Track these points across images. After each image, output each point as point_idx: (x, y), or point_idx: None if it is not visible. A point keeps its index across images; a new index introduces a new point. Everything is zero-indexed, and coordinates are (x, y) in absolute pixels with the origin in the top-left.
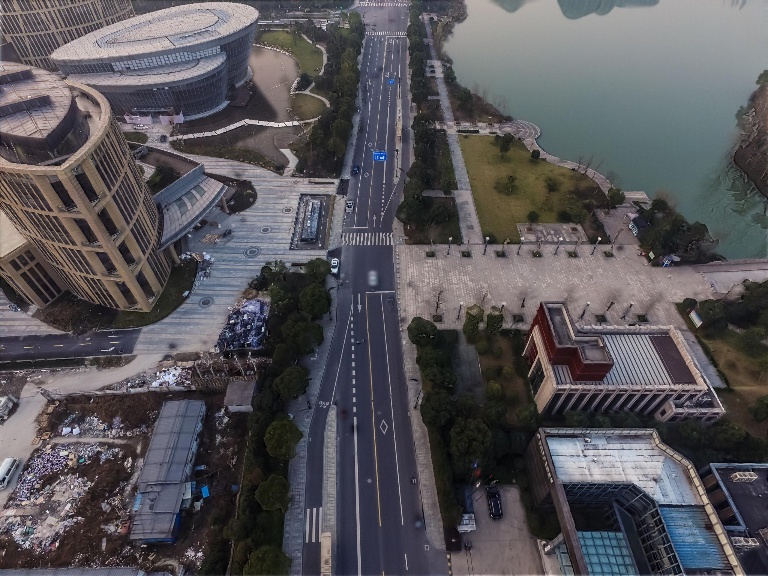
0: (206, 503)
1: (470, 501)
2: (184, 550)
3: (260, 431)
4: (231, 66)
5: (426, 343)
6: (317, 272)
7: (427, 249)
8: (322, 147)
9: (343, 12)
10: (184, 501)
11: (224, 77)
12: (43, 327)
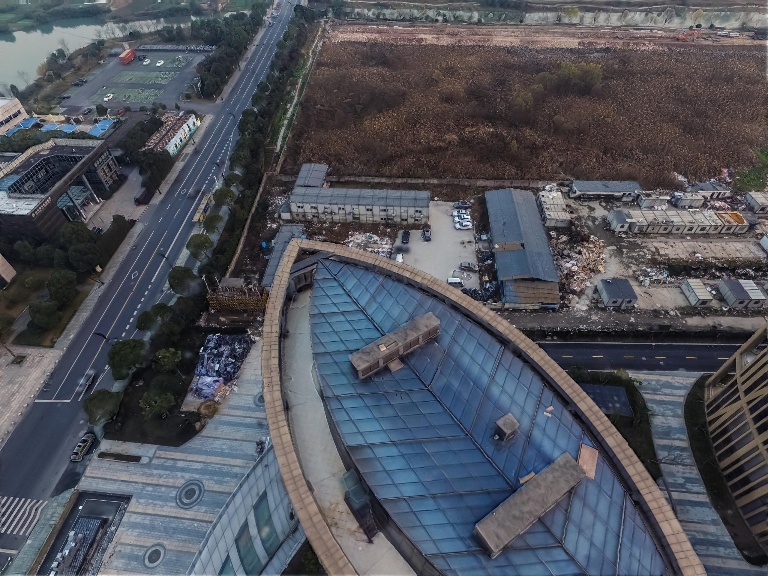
0: None
1: None
2: (277, 227)
3: None
4: None
5: None
6: (106, 390)
7: None
8: None
9: None
10: None
11: None
12: None
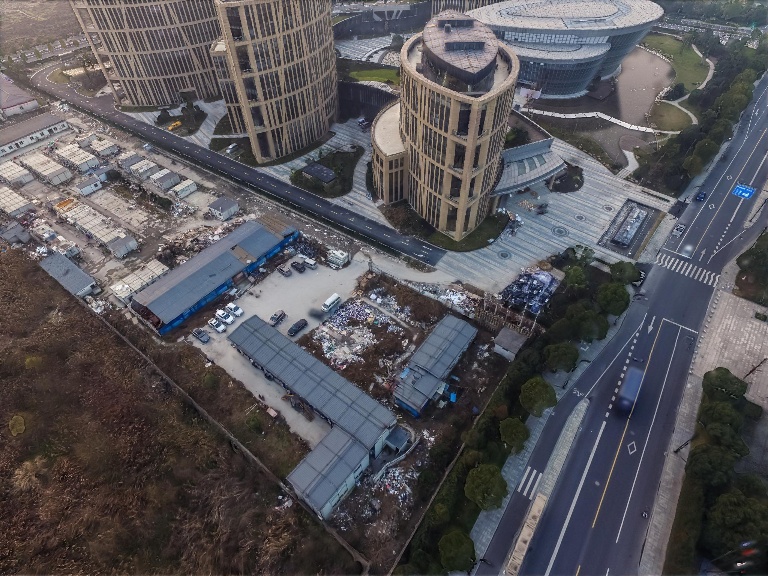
0: (449, 406)
1: (704, 575)
2: (422, 428)
3: (518, 379)
4: (607, 58)
5: (721, 399)
6: (624, 275)
7: (759, 310)
8: (673, 162)
9: (758, 29)
10: (437, 394)
11: (597, 67)
12: (382, 218)
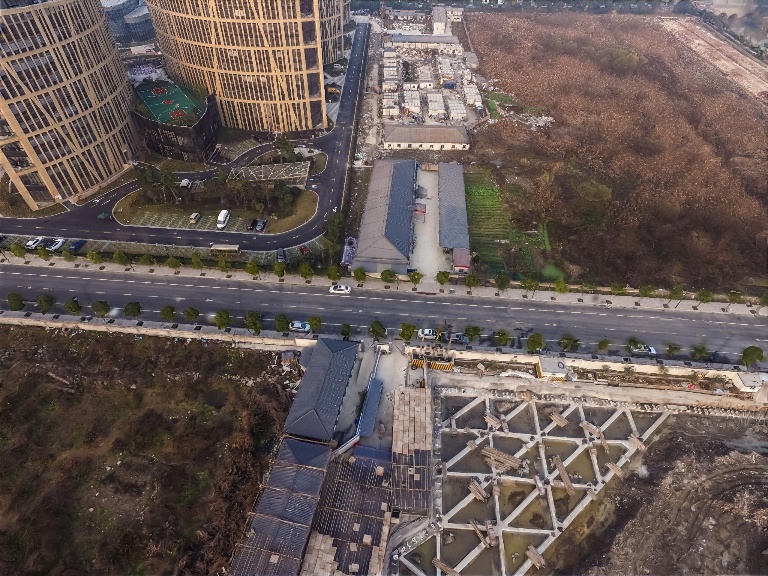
0: None
1: None
2: (427, 16)
3: None
4: None
5: None
6: None
7: None
8: None
9: None
10: None
11: None
12: (351, 32)
